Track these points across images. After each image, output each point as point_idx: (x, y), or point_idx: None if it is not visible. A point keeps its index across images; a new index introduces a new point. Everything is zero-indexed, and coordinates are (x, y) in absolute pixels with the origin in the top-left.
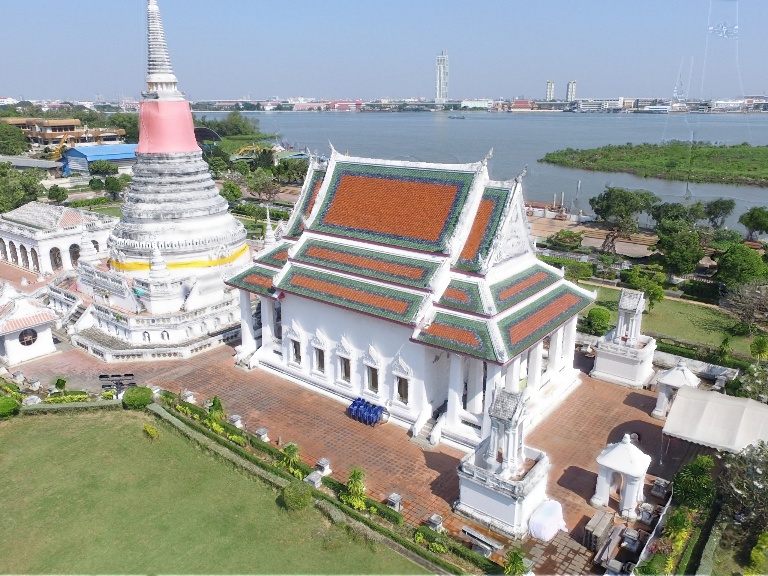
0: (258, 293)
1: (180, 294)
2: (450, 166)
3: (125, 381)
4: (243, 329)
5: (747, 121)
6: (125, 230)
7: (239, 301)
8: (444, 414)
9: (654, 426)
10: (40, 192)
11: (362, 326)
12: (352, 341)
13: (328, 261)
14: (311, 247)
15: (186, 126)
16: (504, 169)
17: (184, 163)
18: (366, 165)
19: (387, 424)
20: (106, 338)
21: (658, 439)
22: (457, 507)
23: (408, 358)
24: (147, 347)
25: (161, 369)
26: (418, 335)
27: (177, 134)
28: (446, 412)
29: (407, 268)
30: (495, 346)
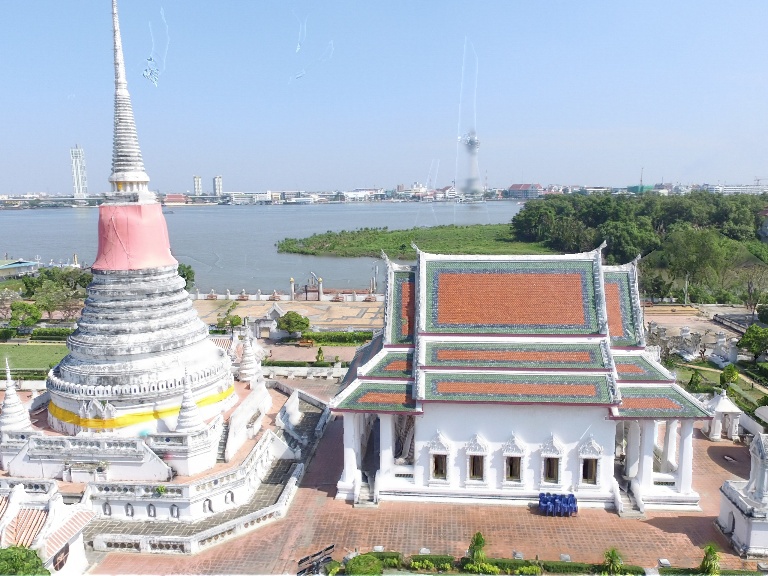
0: (392, 412)
1: (216, 441)
2: (565, 256)
3: (257, 567)
4: (349, 460)
5: (488, 209)
6: (104, 374)
7: (272, 434)
8: (636, 482)
9: (724, 448)
10: None
11: (537, 419)
12: (523, 437)
13: (474, 361)
14: (439, 351)
15: (165, 233)
16: (256, 262)
17: (171, 278)
18: (466, 262)
19: (581, 510)
20: (137, 526)
21: (743, 456)
22: (749, 553)
23: (597, 438)
24: (216, 519)
25: (275, 538)
26: (619, 412)
27: (160, 244)
28: (638, 479)
29: (569, 353)
30: (698, 404)
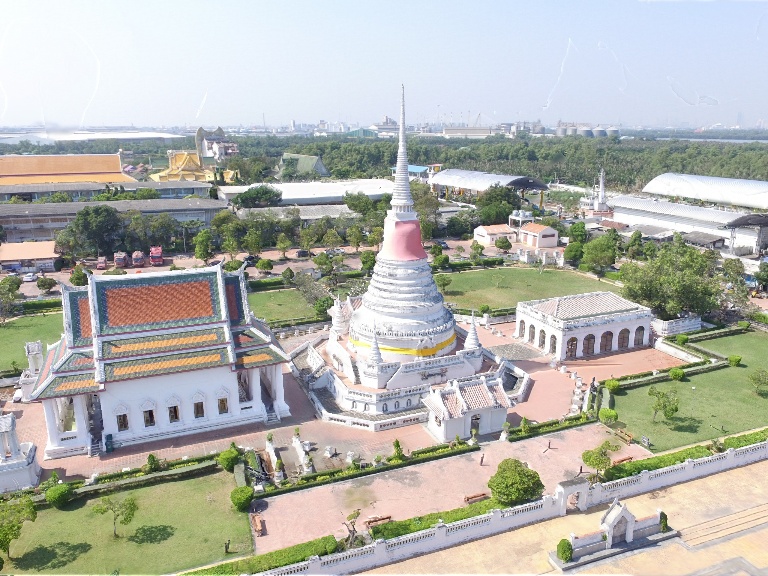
0: None
1: None
2: None
3: None
4: None
5: None
6: None
7: None
8: None
9: None
10: (671, 293)
11: None
12: None
13: None
14: None
15: None
16: None
17: None
18: None
19: None
20: None
21: None
22: None
23: None
24: None
25: None
26: None
27: None
28: None
29: None
30: None
